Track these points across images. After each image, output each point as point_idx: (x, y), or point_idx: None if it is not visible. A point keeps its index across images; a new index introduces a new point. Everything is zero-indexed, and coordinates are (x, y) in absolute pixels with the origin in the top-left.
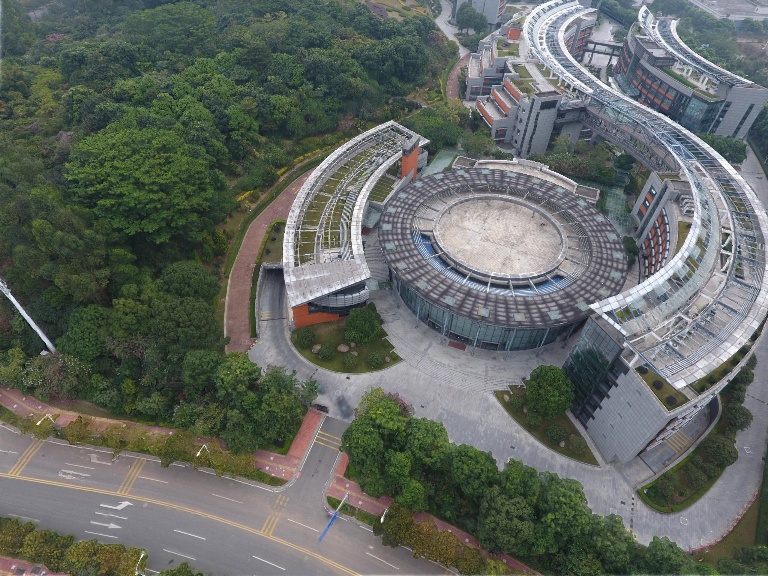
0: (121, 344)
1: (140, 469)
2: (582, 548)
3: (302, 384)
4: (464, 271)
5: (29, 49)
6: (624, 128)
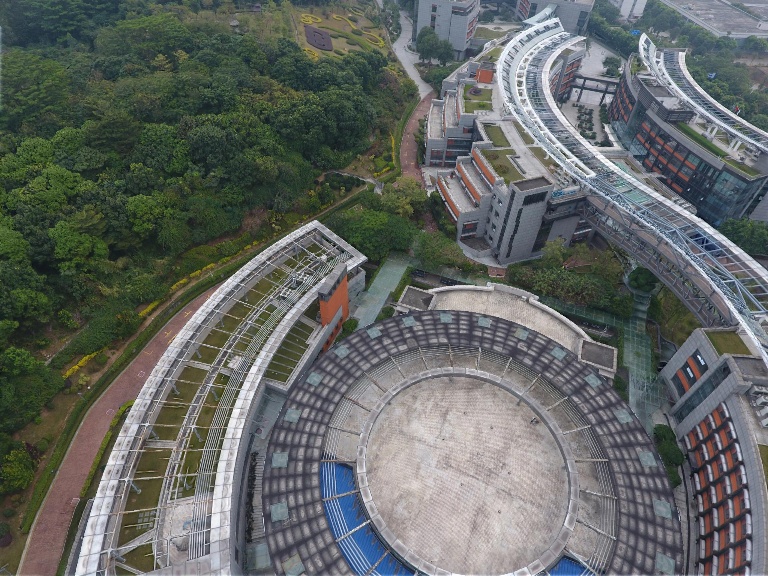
0: None
1: None
2: None
3: None
4: None
5: None
6: (643, 236)
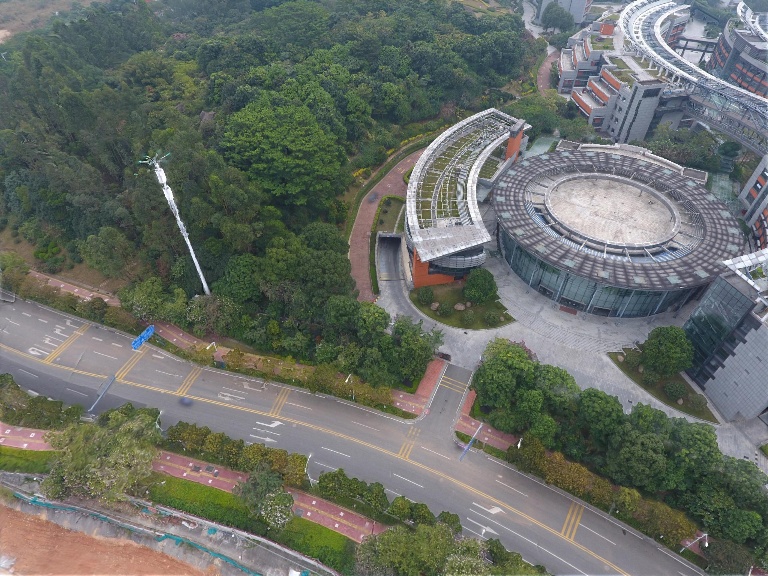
0: (273, 287)
1: (286, 396)
2: (712, 487)
3: (428, 333)
4: (578, 240)
5: (160, 46)
6: (731, 115)
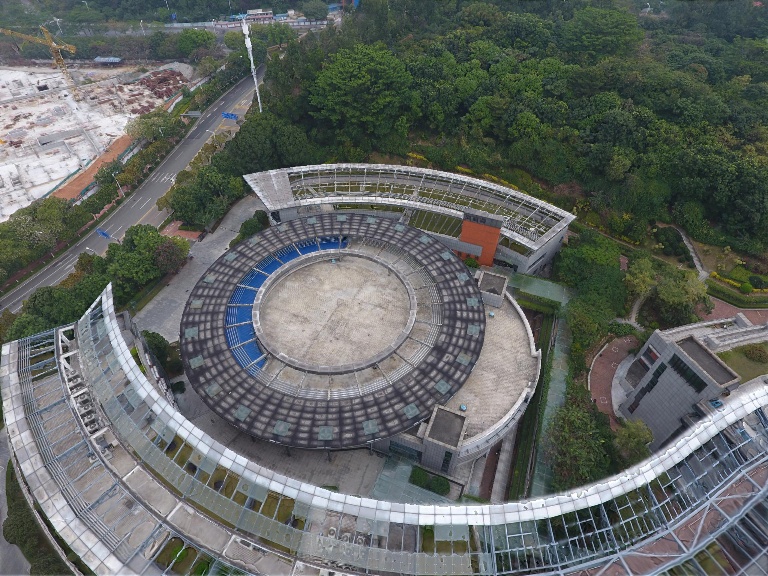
0: None
1: None
2: None
3: None
4: None
5: None
6: None
